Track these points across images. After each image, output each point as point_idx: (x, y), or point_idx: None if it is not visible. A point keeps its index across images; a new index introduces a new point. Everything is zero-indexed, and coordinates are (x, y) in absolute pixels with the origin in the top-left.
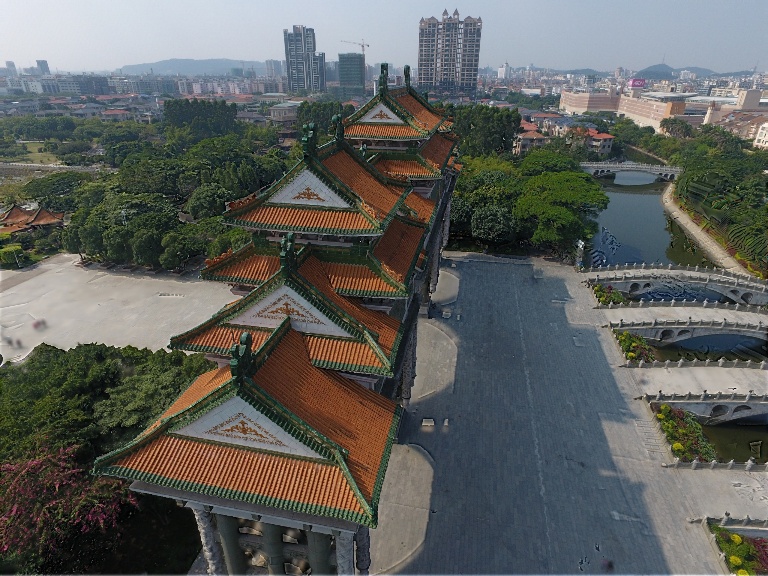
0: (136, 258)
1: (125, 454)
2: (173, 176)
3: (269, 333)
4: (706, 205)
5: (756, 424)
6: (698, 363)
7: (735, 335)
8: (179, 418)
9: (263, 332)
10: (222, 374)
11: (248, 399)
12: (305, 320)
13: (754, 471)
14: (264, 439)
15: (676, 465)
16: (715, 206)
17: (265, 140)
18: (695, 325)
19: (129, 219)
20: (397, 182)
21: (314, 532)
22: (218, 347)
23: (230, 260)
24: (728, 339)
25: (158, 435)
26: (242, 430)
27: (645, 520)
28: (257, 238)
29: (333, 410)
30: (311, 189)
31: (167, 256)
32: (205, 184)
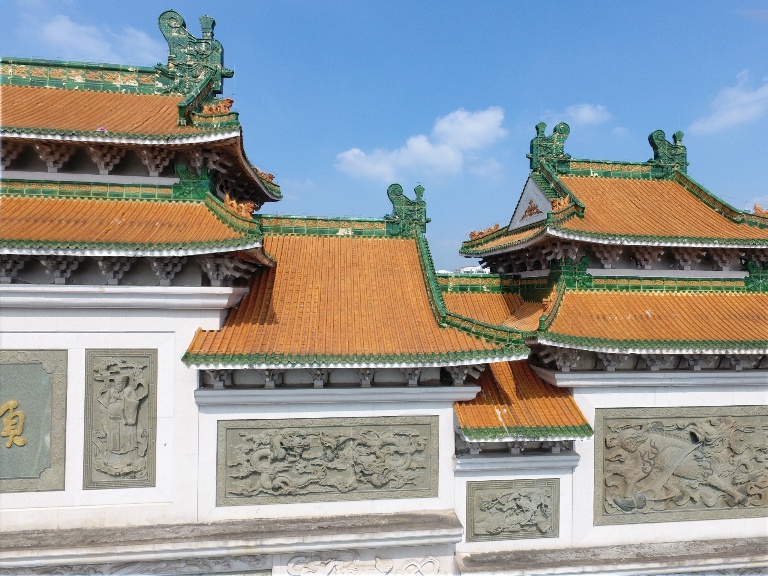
0: None
1: None
2: None
3: None
4: None
5: None
6: None
7: None
8: None
9: None
10: None
11: None
12: None
13: None
14: None
15: None
16: None
17: None
18: None
19: None
20: (486, 238)
21: None
22: None
23: None
24: None
25: None
26: None
27: None
28: None
29: None
30: None
31: None
32: None
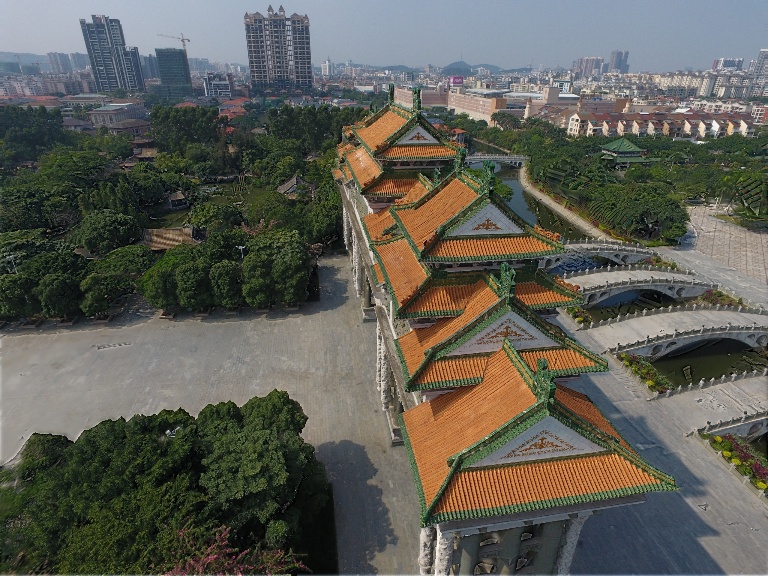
0: (46, 310)
1: (438, 500)
2: (35, 205)
3: (485, 357)
4: (564, 187)
5: (680, 354)
6: (630, 316)
7: (637, 290)
8: (470, 452)
9: (479, 357)
10: (448, 405)
11: (556, 416)
12: (520, 339)
13: (704, 388)
14: (557, 448)
15: (656, 397)
16: (572, 187)
17: (116, 152)
18: (611, 287)
19: (17, 264)
20: None
21: (563, 520)
22: (447, 380)
23: (416, 296)
24: (633, 294)
25: (453, 474)
26: (540, 446)
27: (660, 444)
28: (436, 271)
29: (574, 410)
30: (491, 220)
31: (91, 301)
32: (96, 211)
